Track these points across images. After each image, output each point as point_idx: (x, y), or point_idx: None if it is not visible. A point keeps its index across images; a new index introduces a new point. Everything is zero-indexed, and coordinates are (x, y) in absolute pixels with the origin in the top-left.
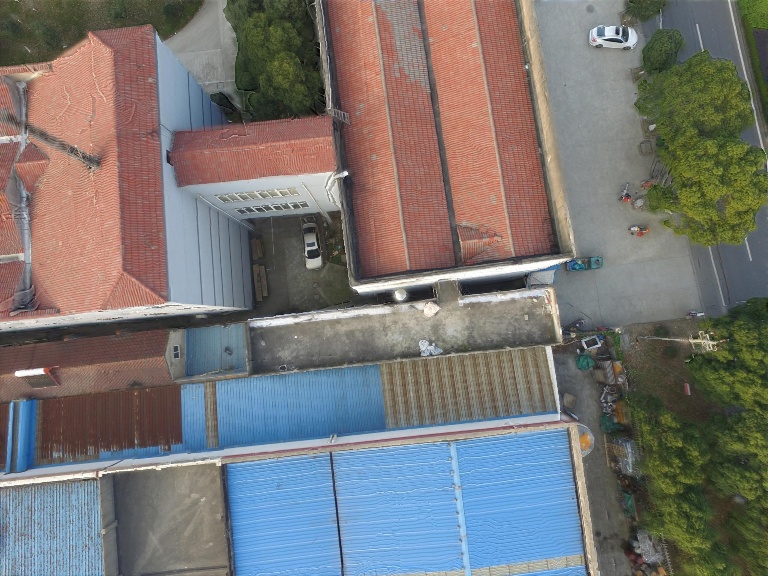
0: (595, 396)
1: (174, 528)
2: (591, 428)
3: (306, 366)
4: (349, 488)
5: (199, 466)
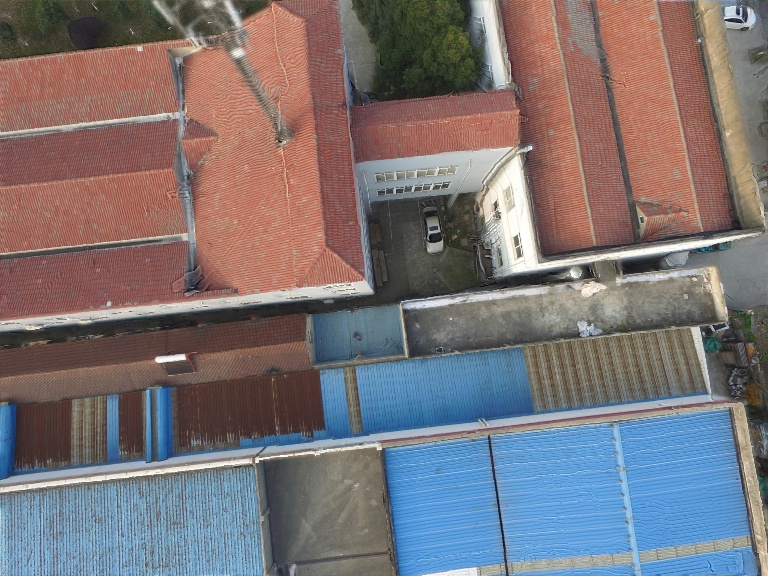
0: (722, 379)
1: (328, 515)
2: None
3: (463, 348)
4: (509, 471)
5: (351, 451)
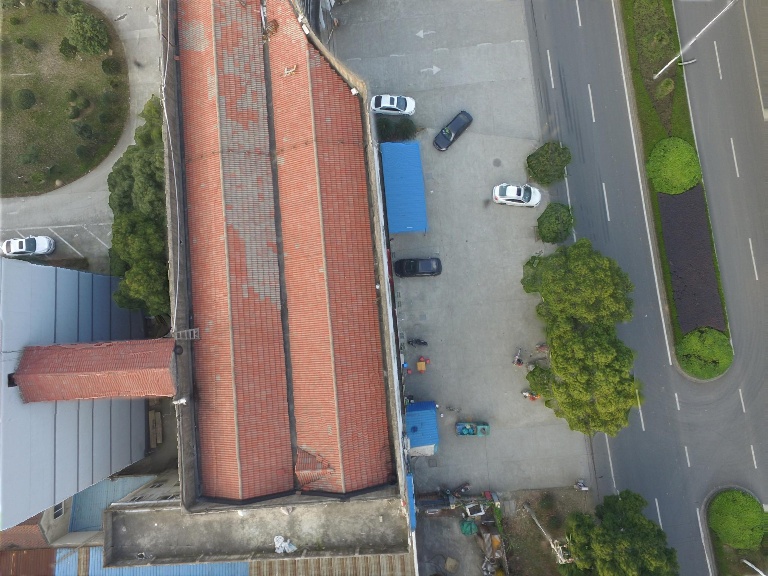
0: (478, 562)
1: None
2: None
3: (164, 555)
4: None
5: None
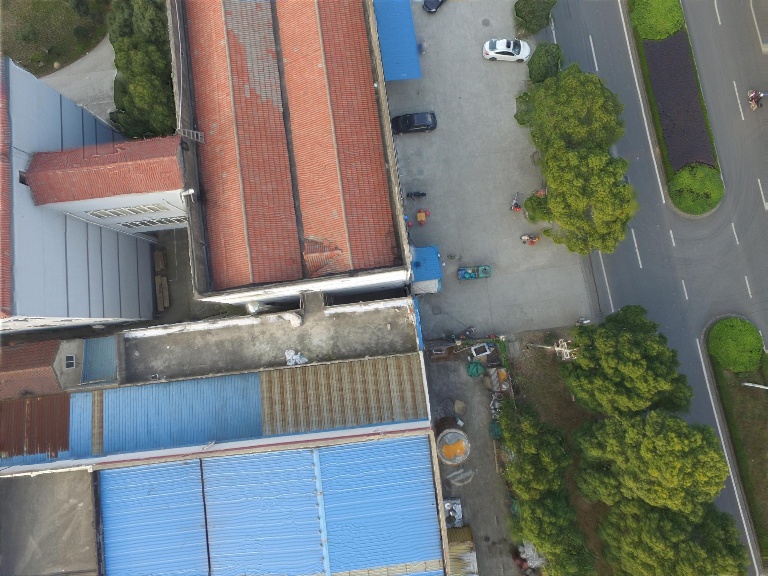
0: (485, 403)
1: (53, 532)
2: (481, 434)
3: (177, 375)
4: (217, 494)
5: (77, 472)
